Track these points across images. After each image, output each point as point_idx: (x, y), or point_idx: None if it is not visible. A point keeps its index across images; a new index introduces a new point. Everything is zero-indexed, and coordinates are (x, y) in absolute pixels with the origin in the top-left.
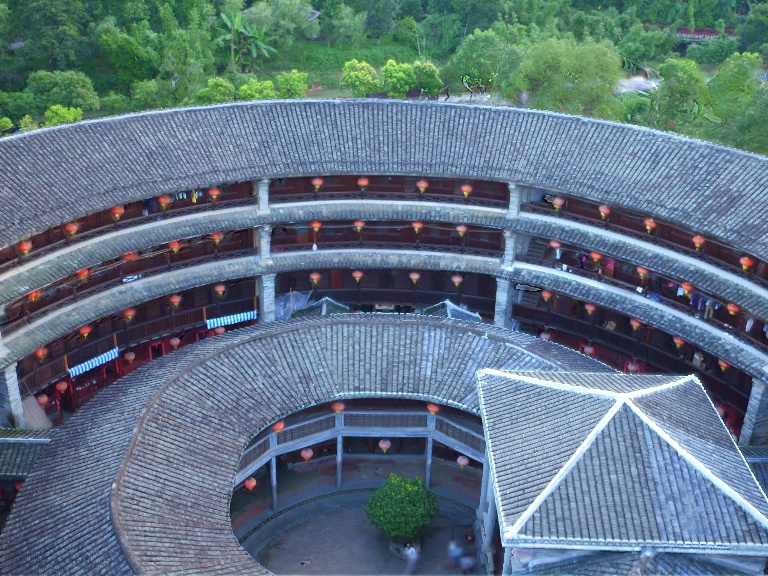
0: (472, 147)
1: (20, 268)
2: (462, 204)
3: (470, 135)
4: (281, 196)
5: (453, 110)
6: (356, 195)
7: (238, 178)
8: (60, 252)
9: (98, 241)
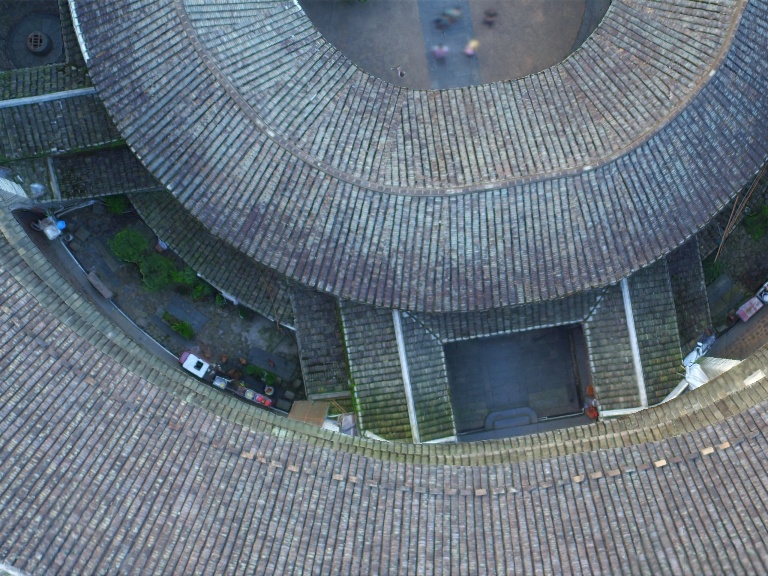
0: None
1: None
2: None
3: None
4: None
5: None
6: None
7: None
8: None
9: None
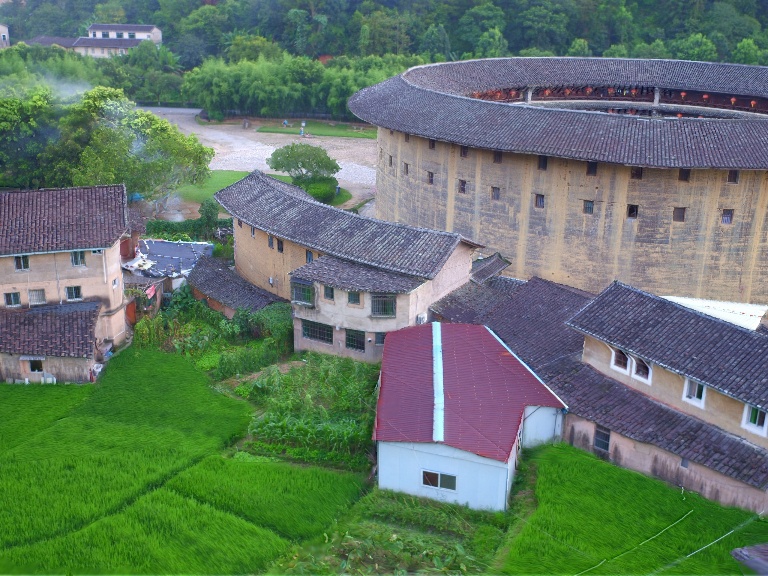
0: (763, 84)
1: (544, 101)
2: (753, 112)
3: (766, 79)
4: (666, 100)
5: (766, 70)
6: (703, 104)
7: (644, 85)
8: (561, 101)
9: (578, 101)
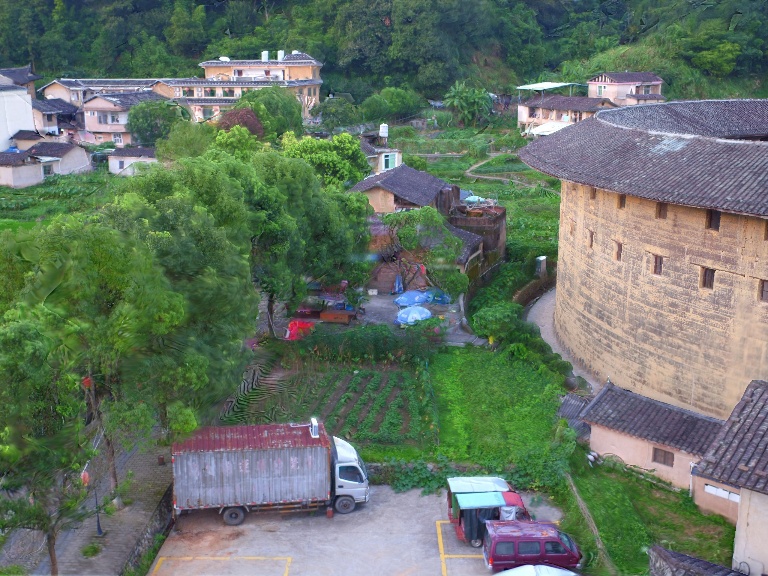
0: None
1: None
2: None
3: None
4: None
5: None
6: None
7: None
8: None
9: None
